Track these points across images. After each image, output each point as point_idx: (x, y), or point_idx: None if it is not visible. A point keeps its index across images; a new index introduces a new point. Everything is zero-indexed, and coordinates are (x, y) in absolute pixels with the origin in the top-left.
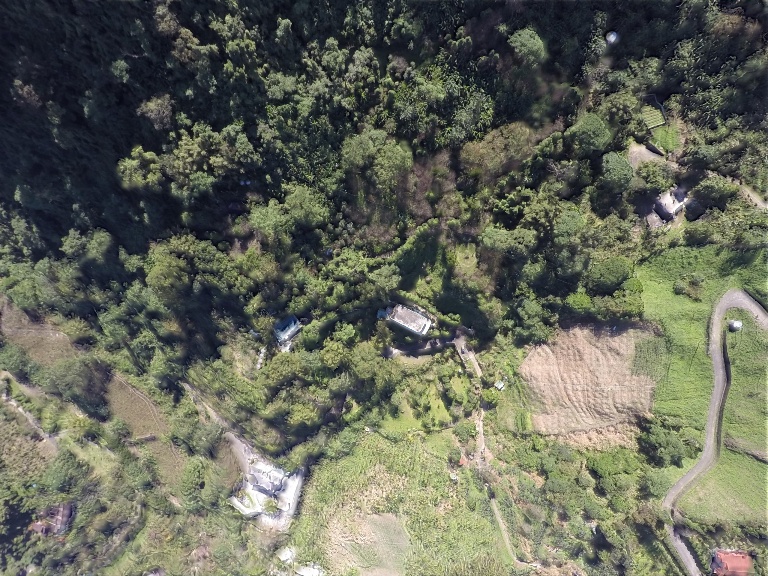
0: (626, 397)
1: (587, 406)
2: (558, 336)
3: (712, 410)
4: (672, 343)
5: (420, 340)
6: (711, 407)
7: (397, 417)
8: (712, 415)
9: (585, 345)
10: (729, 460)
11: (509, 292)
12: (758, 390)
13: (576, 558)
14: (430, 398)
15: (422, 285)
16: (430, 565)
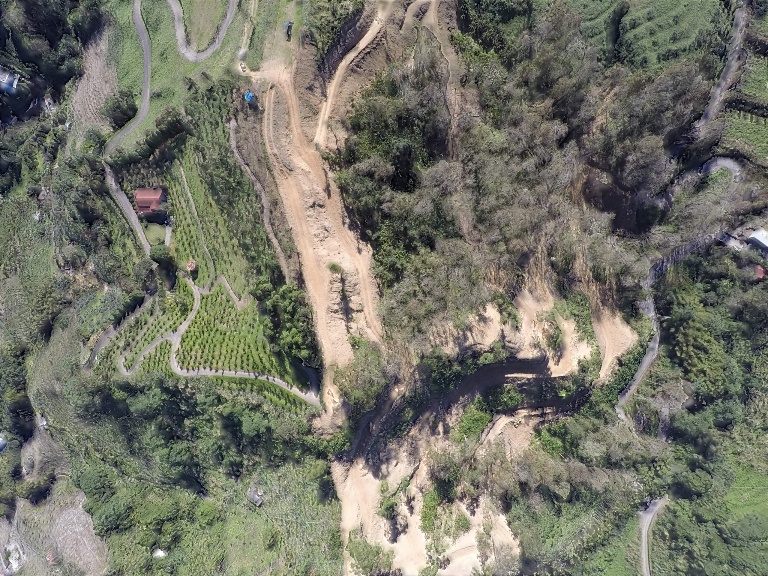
0: (108, 87)
1: (95, 109)
2: (86, 60)
3: (146, 72)
4: (120, 24)
5: (17, 96)
6: (145, 70)
7: (21, 181)
8: (146, 77)
9: (94, 57)
10: (150, 108)
11: (62, 36)
12: (158, 38)
13: (84, 246)
14: (38, 156)
15: (9, 44)
16: (6, 290)
